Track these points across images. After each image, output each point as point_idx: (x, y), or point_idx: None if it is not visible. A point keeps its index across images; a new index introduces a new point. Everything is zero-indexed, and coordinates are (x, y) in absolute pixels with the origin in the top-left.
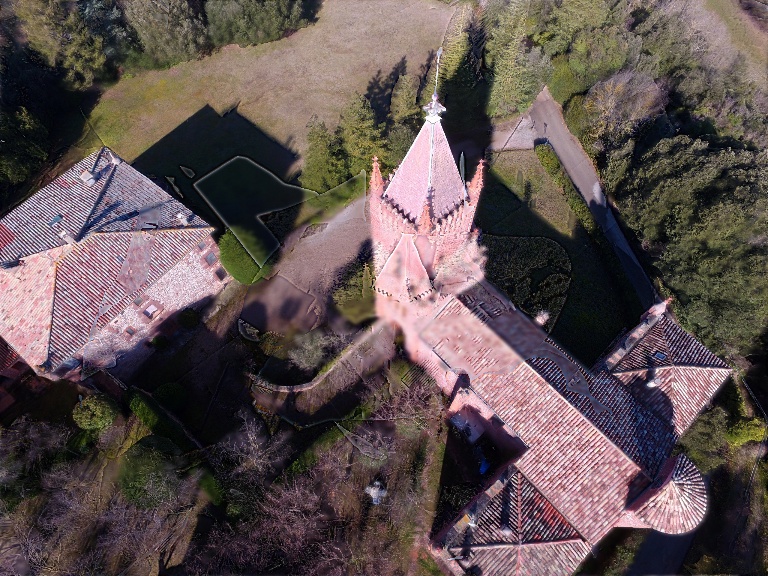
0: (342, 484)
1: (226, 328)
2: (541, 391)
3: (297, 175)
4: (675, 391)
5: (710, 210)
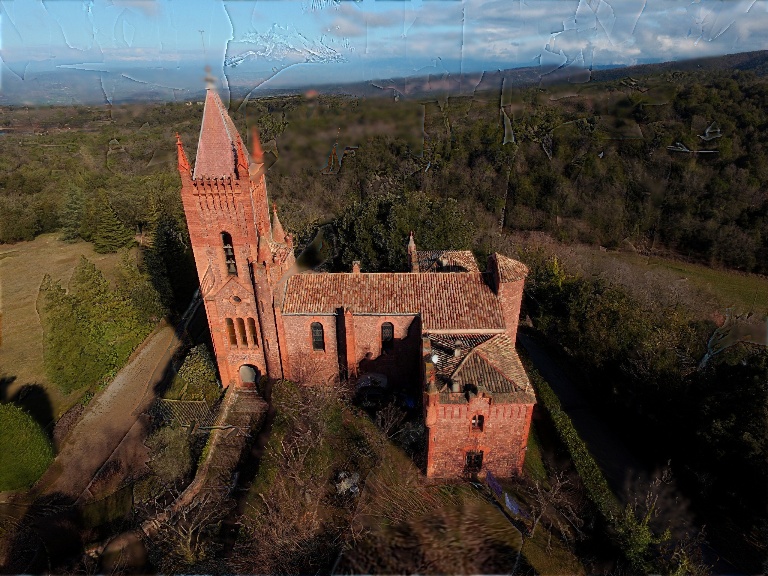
0: (310, 511)
1: (15, 551)
2: (394, 279)
3: (28, 391)
4: (458, 262)
5: (390, 214)
